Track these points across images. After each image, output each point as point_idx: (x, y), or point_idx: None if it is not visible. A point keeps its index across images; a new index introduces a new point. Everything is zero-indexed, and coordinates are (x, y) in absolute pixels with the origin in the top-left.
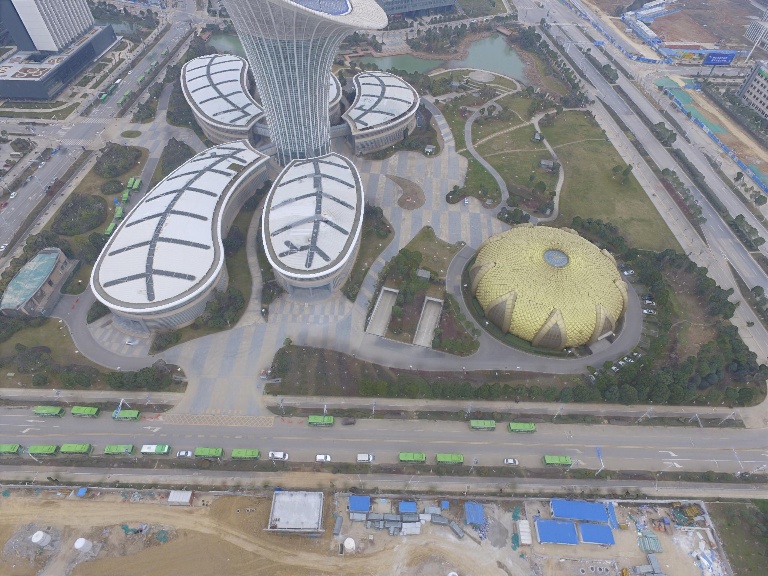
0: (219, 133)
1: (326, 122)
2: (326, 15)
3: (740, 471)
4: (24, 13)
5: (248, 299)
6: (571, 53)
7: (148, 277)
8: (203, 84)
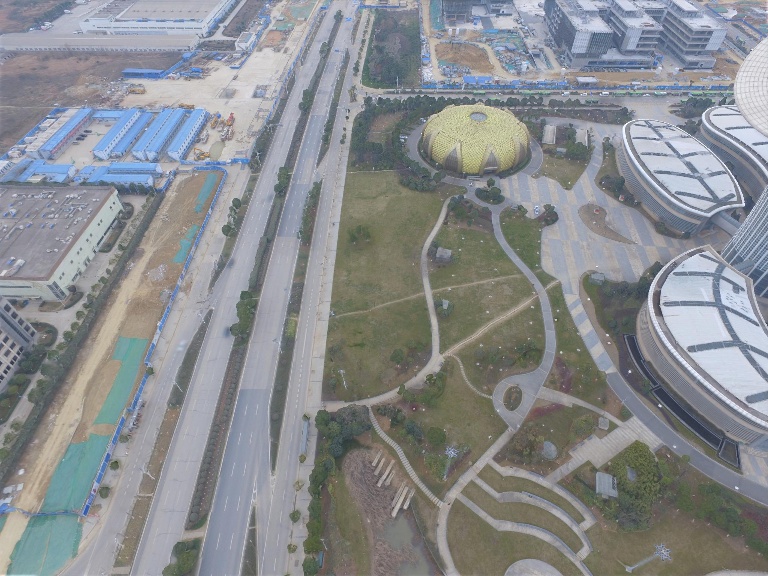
0: None
1: None
2: None
3: None
4: None
5: None
6: None
7: None
8: None
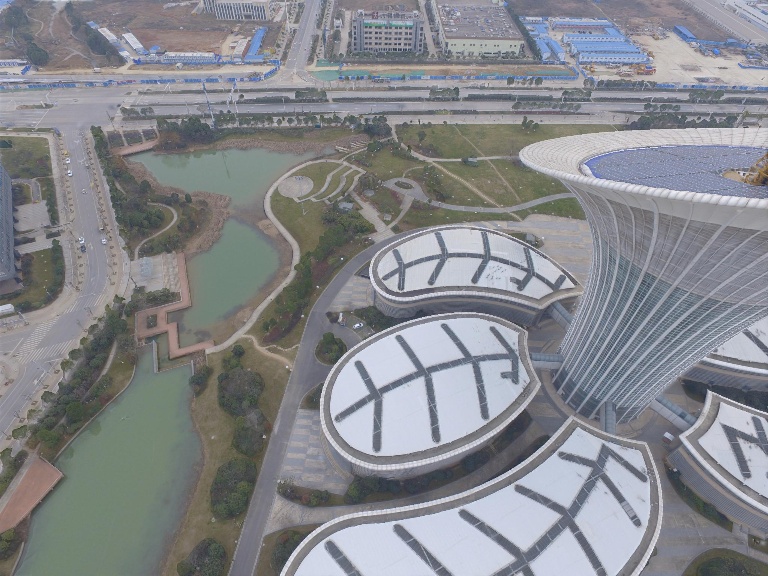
0: None
1: None
2: None
3: None
4: None
5: None
6: (235, 111)
7: None
8: None
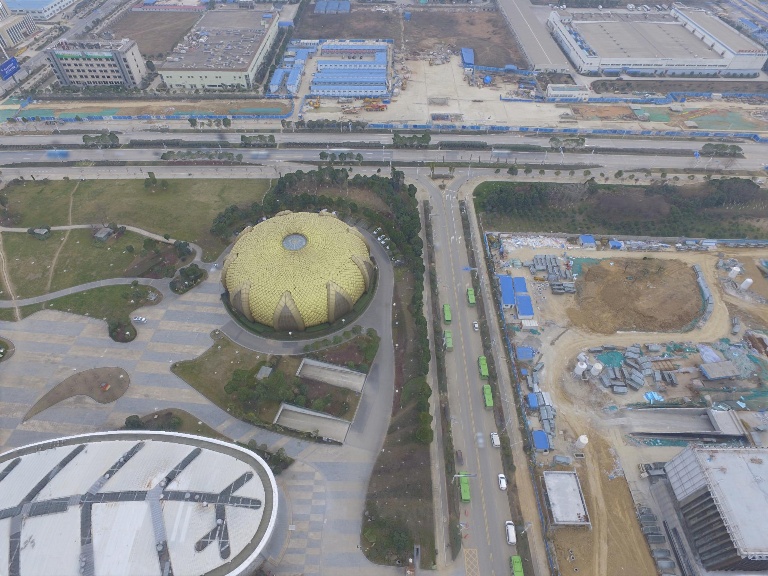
0: None
1: None
2: None
3: (459, 212)
4: None
5: None
6: None
7: None
8: None
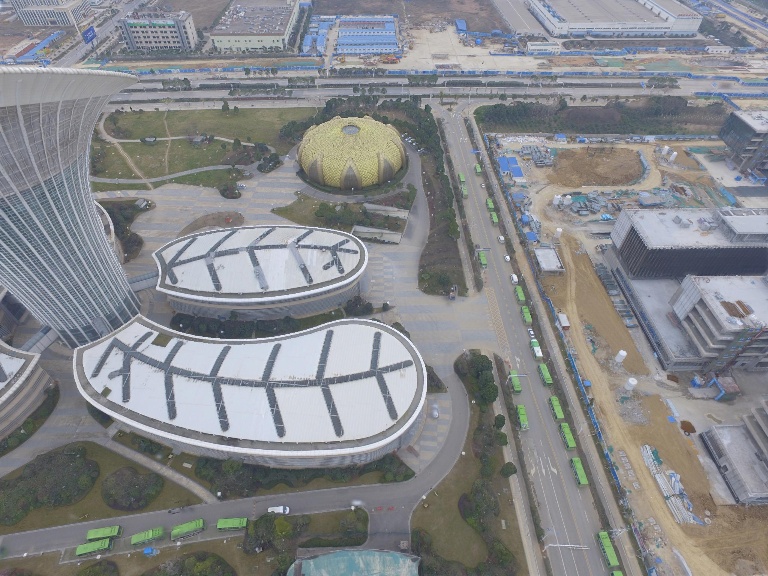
0: (1, 416)
1: None
2: None
3: (464, 124)
4: None
5: None
6: None
7: (382, 372)
8: None
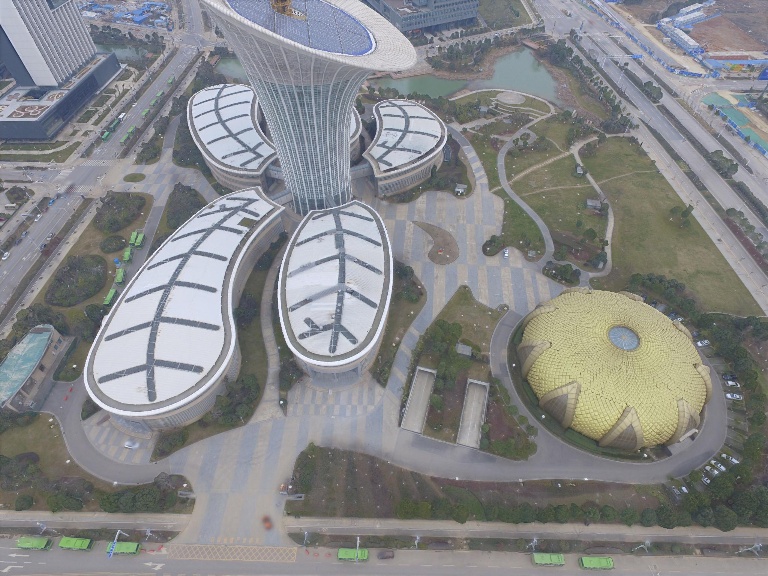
0: (229, 177)
1: (346, 166)
2: (350, 61)
3: None
4: (21, 48)
5: (264, 385)
6: (606, 68)
7: (149, 370)
8: (211, 121)
